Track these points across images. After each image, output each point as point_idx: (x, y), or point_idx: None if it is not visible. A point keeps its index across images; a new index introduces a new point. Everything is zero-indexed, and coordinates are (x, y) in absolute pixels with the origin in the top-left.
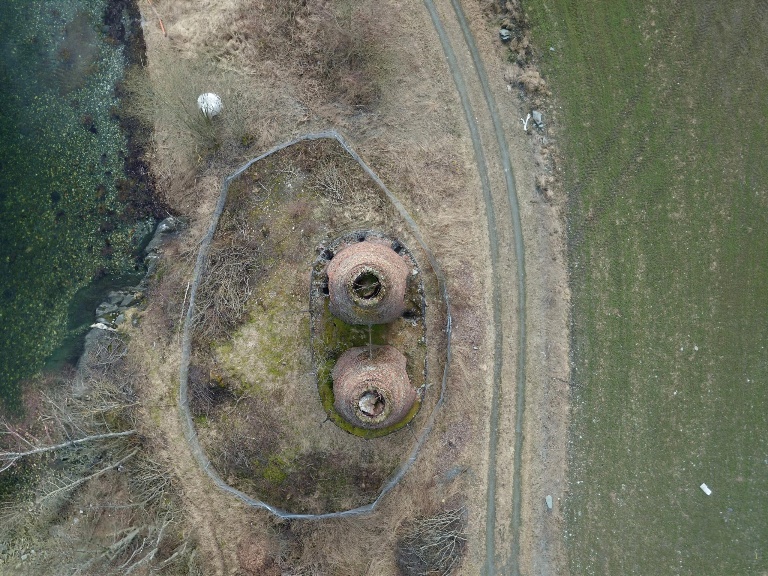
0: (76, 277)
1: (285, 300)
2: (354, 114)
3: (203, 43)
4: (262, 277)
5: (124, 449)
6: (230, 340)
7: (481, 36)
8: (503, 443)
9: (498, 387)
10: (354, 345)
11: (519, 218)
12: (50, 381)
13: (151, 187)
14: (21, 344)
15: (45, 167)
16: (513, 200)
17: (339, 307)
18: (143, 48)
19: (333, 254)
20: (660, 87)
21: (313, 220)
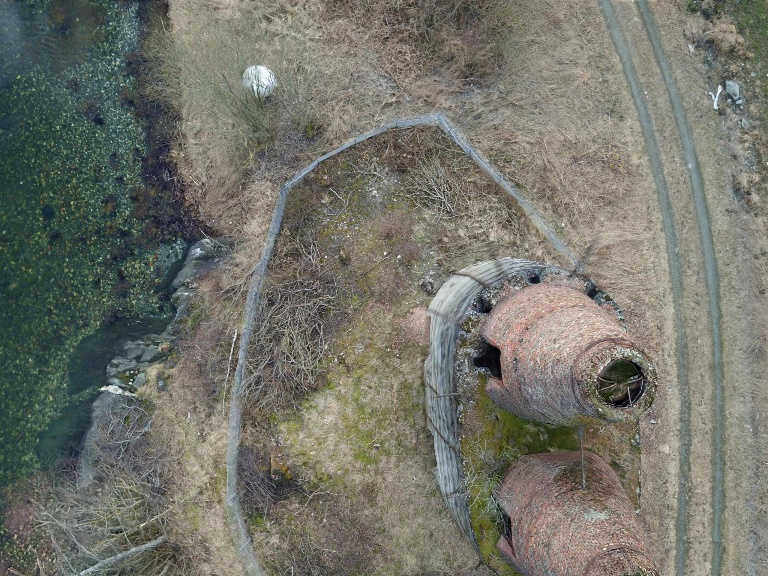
0: (78, 322)
1: (377, 356)
2: (463, 91)
3: None
4: (342, 323)
5: (150, 564)
6: (298, 413)
7: None
8: (695, 557)
9: (686, 477)
10: (529, 450)
11: (710, 234)
12: (46, 464)
13: (179, 197)
14: (5, 414)
15: (33, 172)
16: (701, 209)
17: (527, 401)
18: (164, 6)
19: (491, 304)
20: None
21: (414, 241)
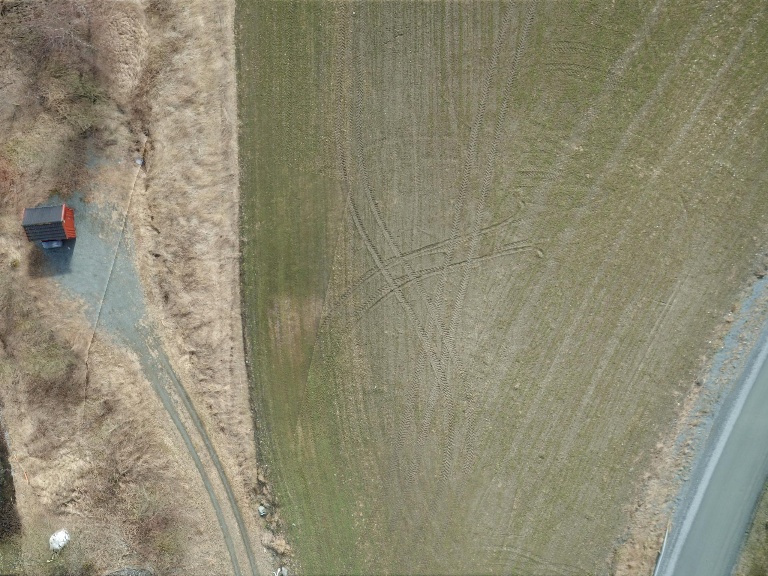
0: None
1: None
2: (161, 553)
3: (55, 493)
4: None
5: None
6: None
7: (245, 512)
8: None
9: None
10: None
11: None
12: None
13: None
14: None
15: None
16: None
17: None
18: (13, 491)
19: None
20: (366, 560)
21: None
